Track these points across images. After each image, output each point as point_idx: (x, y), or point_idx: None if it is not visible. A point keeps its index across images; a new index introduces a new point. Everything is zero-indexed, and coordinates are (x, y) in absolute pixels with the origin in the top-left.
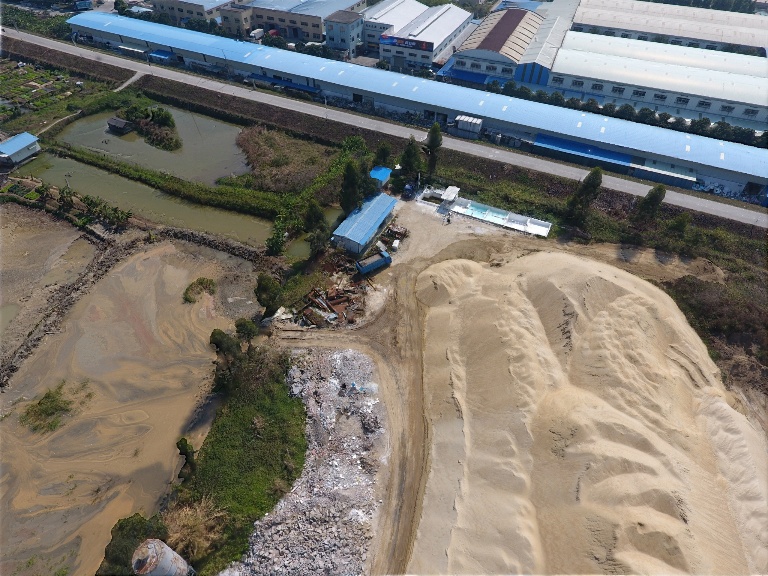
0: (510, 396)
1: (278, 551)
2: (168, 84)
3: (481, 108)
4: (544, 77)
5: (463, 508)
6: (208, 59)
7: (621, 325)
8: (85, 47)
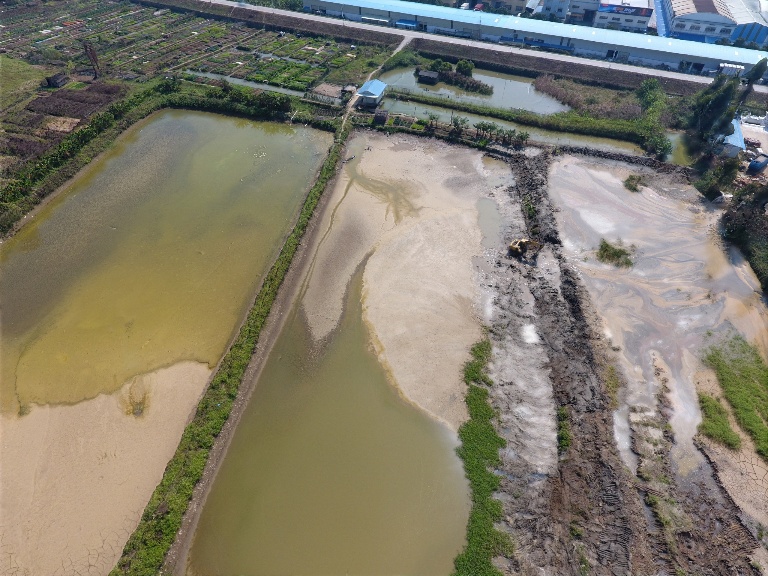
0: None
1: None
2: (441, 45)
3: (739, 57)
4: (762, 35)
5: None
6: (457, 25)
7: None
8: (335, 18)
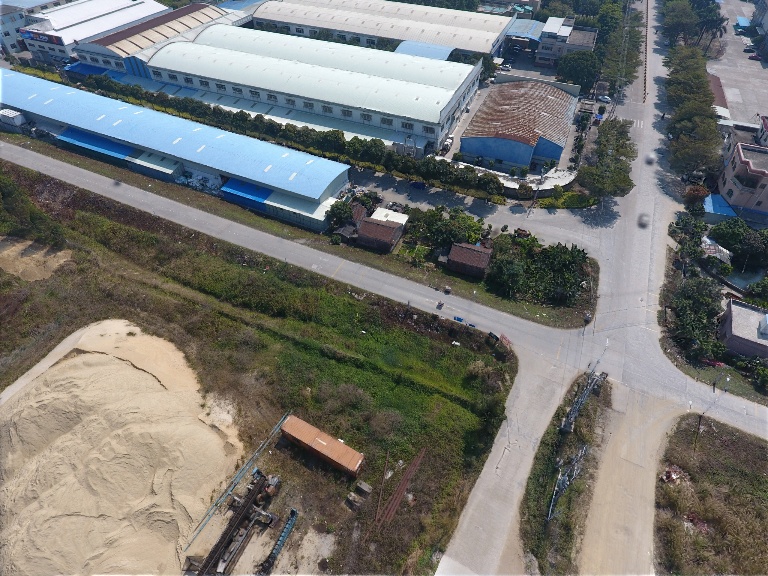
0: None
1: None
2: None
3: (26, 101)
4: (147, 71)
5: None
6: None
7: None
8: None
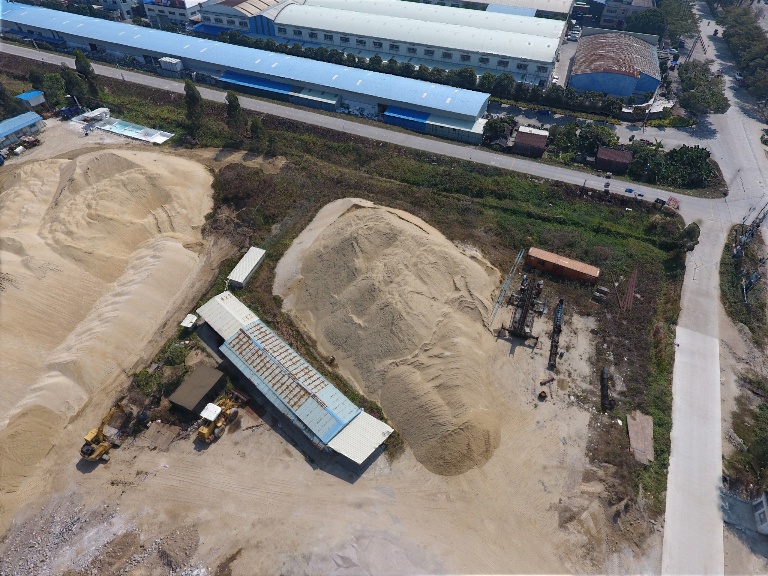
0: None
1: None
2: None
3: (183, 50)
4: (272, 28)
5: None
6: None
7: (104, 185)
8: None
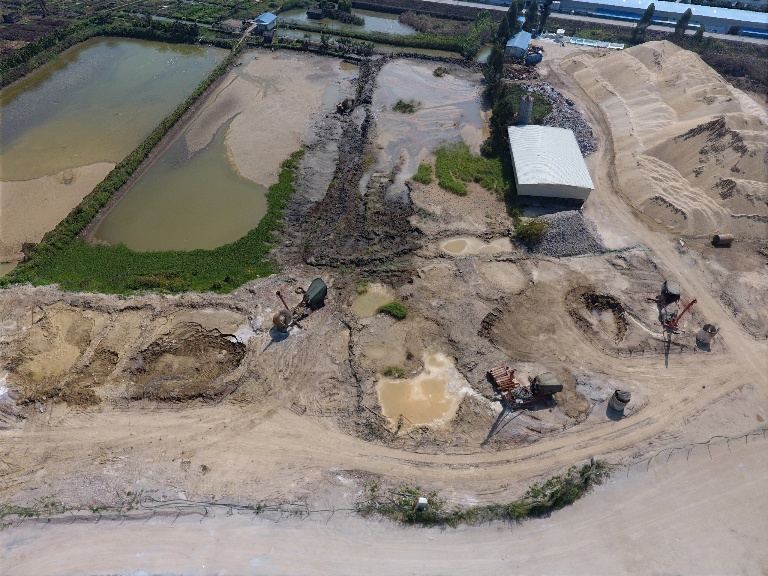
0: (639, 80)
1: None
2: None
3: None
4: None
5: None
6: None
7: (684, 57)
8: None
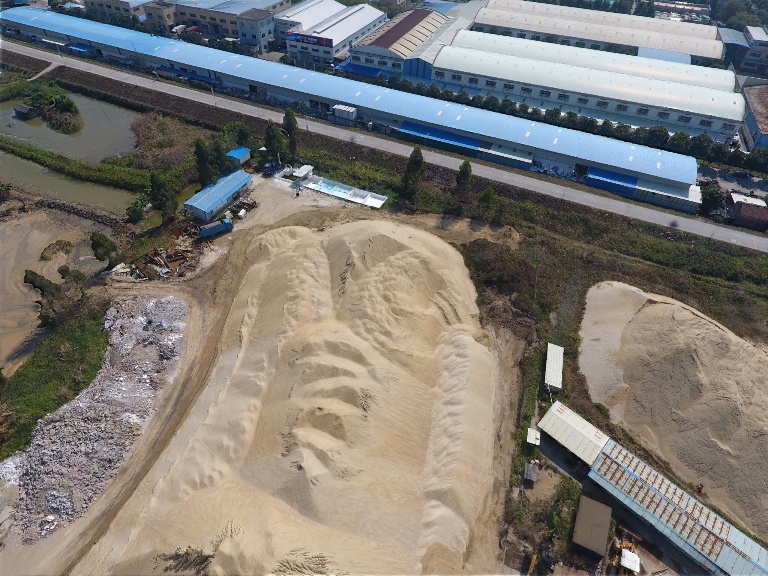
0: (277, 327)
1: (51, 441)
2: (79, 74)
3: (357, 98)
4: (428, 71)
5: (215, 411)
6: (122, 52)
7: (389, 273)
8: (9, 40)
